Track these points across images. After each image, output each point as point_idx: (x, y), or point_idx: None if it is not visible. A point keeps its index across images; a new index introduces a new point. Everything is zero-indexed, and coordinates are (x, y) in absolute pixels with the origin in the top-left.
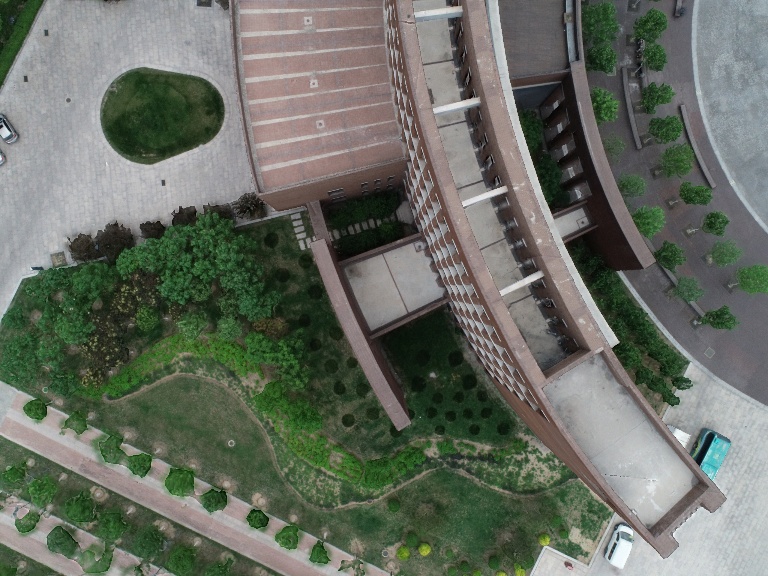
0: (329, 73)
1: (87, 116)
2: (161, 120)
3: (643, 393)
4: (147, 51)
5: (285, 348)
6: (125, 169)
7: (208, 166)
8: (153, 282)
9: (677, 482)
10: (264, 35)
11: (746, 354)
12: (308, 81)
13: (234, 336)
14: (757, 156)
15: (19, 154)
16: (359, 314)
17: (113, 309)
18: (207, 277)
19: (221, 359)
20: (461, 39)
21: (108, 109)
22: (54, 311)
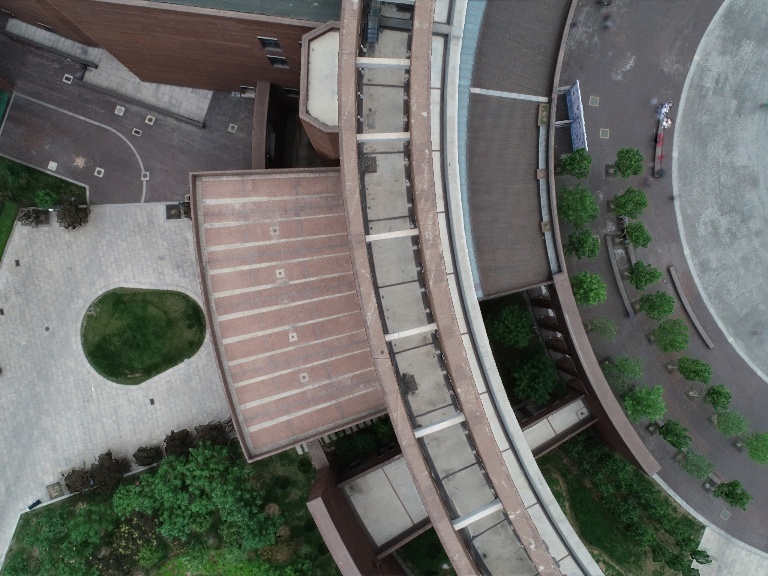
0: (307, 325)
1: (68, 343)
2: (143, 339)
3: (661, 563)
4: (121, 270)
5: (293, 575)
6: (112, 392)
7: (195, 380)
8: (152, 525)
9: None
10: (237, 293)
11: (762, 512)
12: (287, 335)
13: (240, 560)
14: (753, 309)
15: (3, 388)
16: (364, 533)
17: (115, 550)
18: (206, 510)
19: (230, 575)
20: (439, 342)
21: (88, 333)
22: (56, 543)
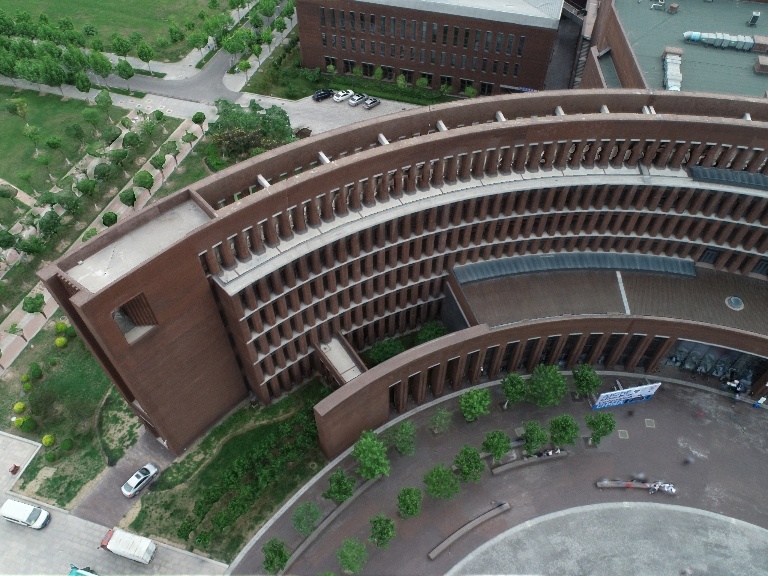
0: None
1: None
2: None
3: None
4: None
5: None
6: None
7: None
8: None
9: (101, 288)
10: None
11: None
12: None
13: None
14: None
15: (358, 111)
16: None
17: None
18: None
19: None
20: None
21: None
22: None
